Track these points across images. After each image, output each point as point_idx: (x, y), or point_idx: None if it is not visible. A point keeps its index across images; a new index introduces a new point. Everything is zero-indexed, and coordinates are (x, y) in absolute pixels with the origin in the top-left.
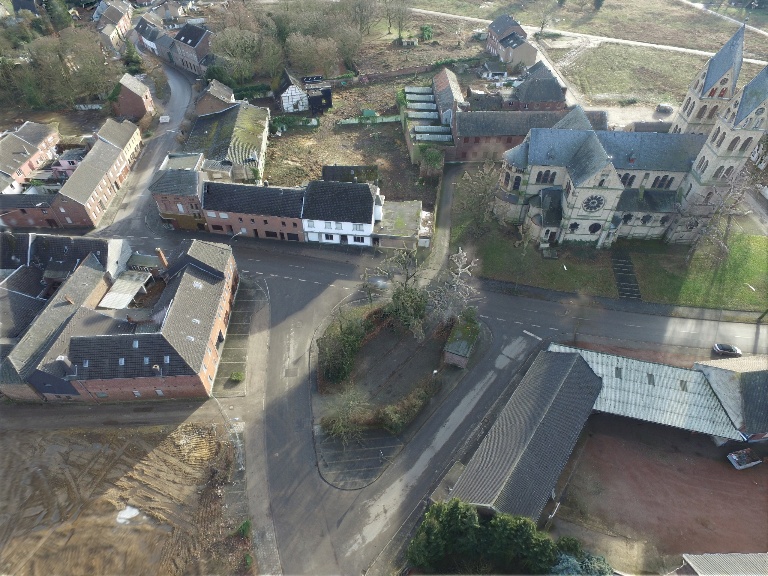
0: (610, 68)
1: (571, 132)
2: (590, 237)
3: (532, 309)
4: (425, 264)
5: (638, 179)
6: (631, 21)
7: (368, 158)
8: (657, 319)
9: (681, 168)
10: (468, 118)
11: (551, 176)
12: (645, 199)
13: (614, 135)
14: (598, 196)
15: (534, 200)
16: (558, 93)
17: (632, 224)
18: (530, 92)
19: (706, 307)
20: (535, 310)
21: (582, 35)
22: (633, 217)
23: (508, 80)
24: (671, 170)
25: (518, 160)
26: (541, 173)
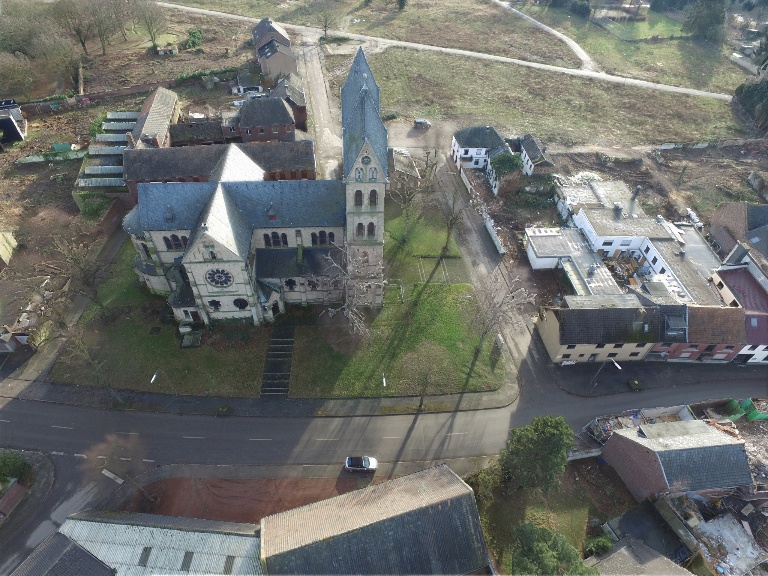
0: (386, 77)
1: (191, 185)
2: (242, 313)
3: (133, 431)
4: (17, 373)
5: (291, 237)
6: (432, 21)
7: (29, 211)
8: (295, 424)
9: (334, 222)
10: (138, 157)
11: (183, 241)
12: (306, 260)
13: (246, 186)
14: (220, 269)
15: (170, 271)
16: (284, 115)
17: (299, 290)
18: (249, 115)
19: (363, 397)
20: (137, 432)
21: (372, 38)
22: (296, 282)
23: (253, 97)
24: (323, 225)
25: (133, 224)
26: (167, 238)
